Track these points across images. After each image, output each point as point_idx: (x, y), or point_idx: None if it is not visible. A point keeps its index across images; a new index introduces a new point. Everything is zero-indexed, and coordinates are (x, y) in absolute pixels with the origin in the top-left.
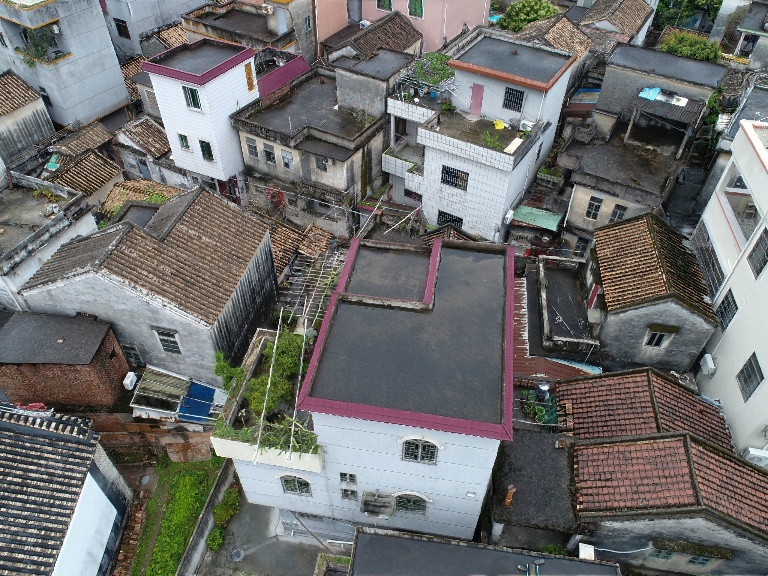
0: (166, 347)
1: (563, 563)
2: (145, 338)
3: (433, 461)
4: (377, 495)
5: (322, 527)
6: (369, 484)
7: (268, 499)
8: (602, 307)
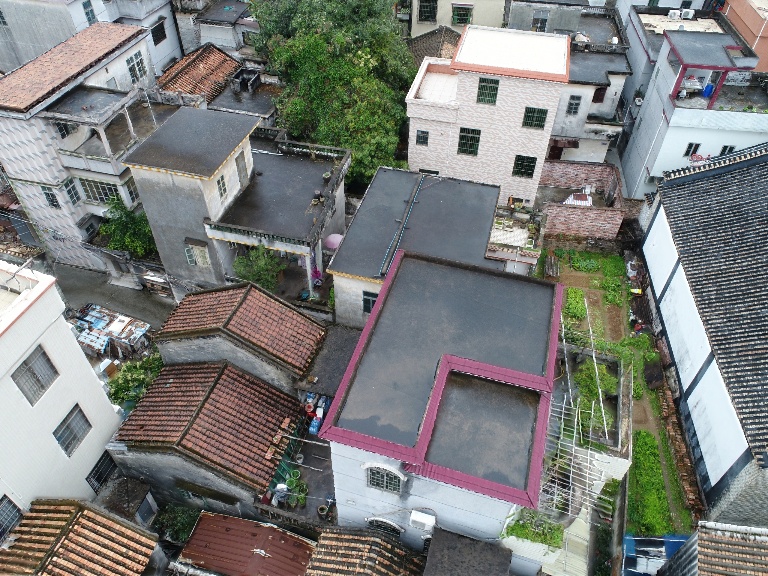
0: None
1: (362, 275)
2: None
3: None
4: None
5: None
6: None
7: None
8: (151, 571)
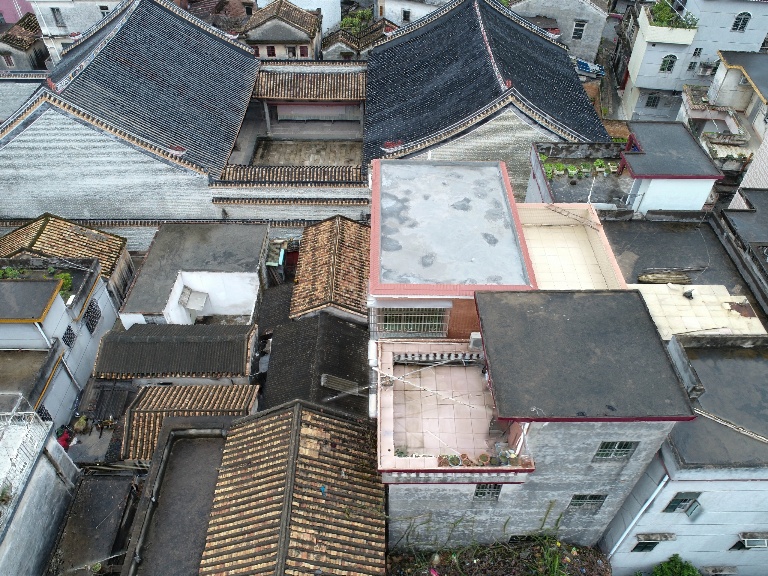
0: (574, 35)
1: None
2: (566, 30)
3: (744, 30)
4: (707, 62)
5: (654, 114)
6: (706, 55)
7: (647, 80)
8: None
